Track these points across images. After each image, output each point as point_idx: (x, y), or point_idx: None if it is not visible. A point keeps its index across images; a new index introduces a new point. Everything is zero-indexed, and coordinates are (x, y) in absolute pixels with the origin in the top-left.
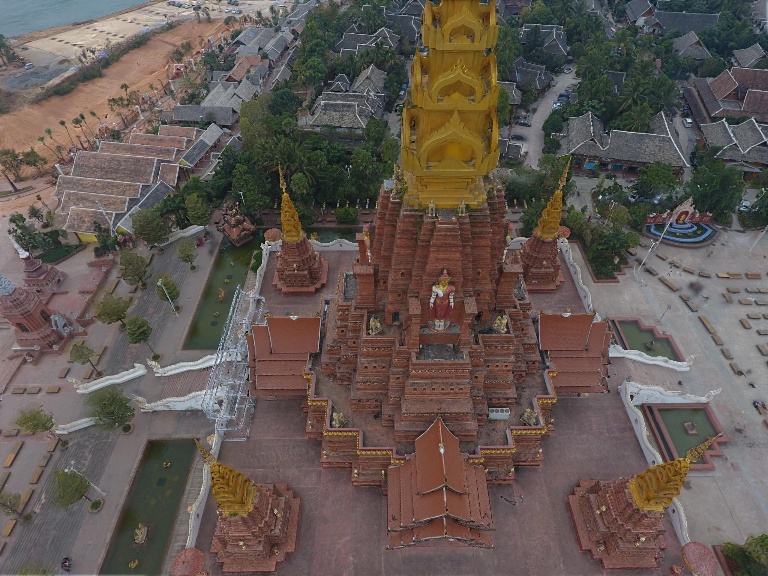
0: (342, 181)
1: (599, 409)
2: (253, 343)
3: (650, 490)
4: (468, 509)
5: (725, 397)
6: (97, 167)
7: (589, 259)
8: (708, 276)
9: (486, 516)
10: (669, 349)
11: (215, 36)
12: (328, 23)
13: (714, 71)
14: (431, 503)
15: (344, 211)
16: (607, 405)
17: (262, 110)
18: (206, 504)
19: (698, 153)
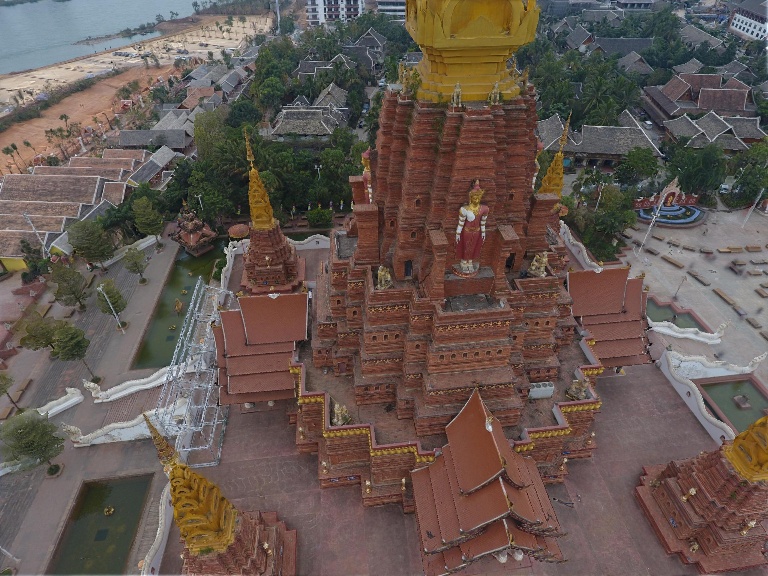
0: (312, 184)
1: (642, 387)
2: (222, 336)
3: (763, 450)
4: (530, 508)
5: (767, 366)
6: (29, 190)
7: (586, 243)
8: (710, 252)
9: (550, 518)
10: (693, 323)
11: (165, 76)
12: (283, 54)
13: (662, 80)
14: (483, 502)
15: (317, 212)
16: (649, 381)
17: (219, 122)
18: (164, 554)
19: (665, 148)
